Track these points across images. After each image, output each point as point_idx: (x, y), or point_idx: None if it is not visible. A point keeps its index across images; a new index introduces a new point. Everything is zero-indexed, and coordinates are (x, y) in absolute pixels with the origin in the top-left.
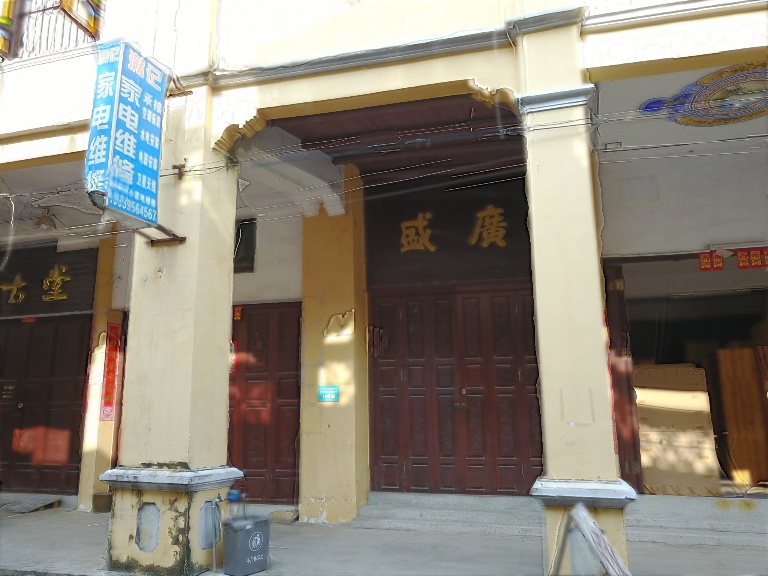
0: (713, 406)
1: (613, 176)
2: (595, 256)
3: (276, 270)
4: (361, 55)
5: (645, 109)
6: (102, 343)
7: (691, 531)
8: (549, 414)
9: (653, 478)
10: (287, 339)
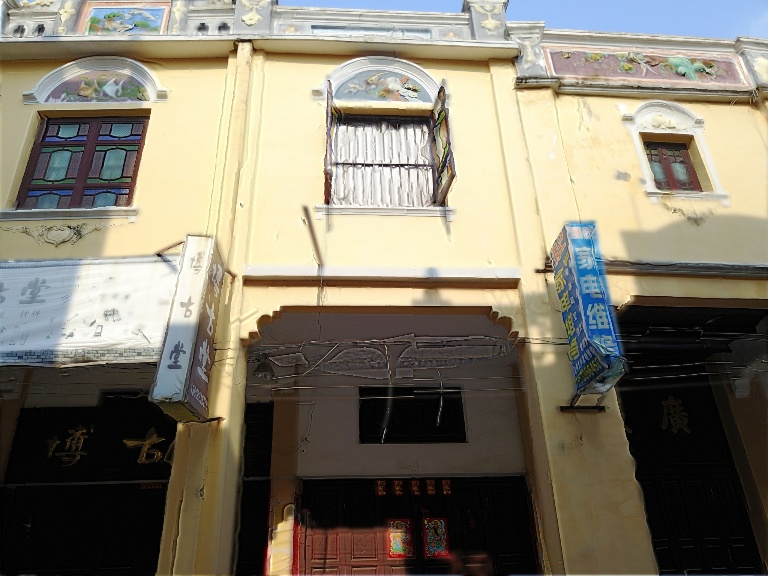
0: None
1: (761, 382)
2: None
3: (493, 442)
4: (722, 267)
5: None
6: (291, 518)
7: None
8: None
9: None
10: (505, 517)
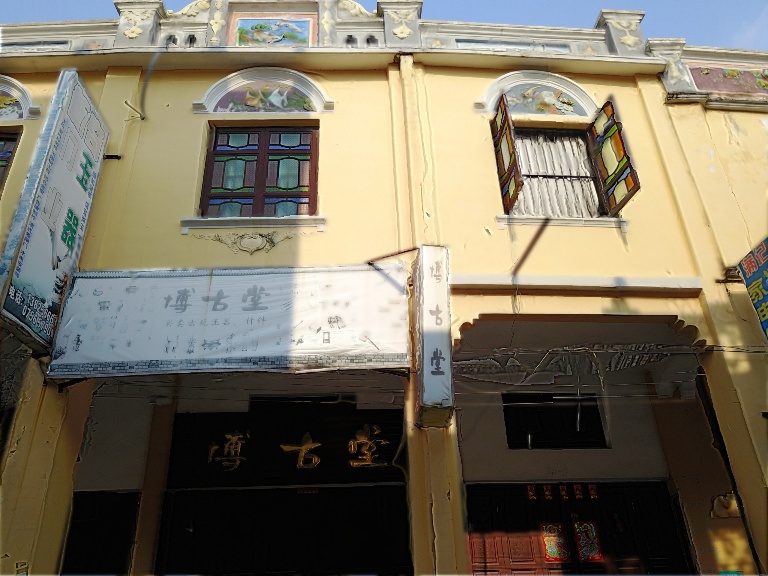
0: None
1: None
2: None
3: (635, 448)
4: None
5: None
6: None
7: None
8: None
9: None
10: (651, 521)
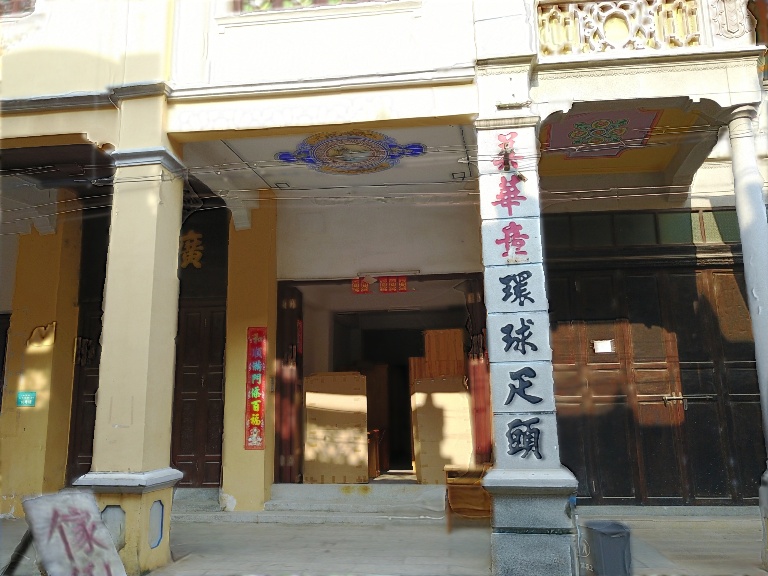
0: (369, 408)
1: (290, 210)
2: (150, 290)
3: None
4: None
5: (280, 160)
6: None
7: (309, 512)
8: (100, 419)
9: (313, 469)
10: (1, 348)
